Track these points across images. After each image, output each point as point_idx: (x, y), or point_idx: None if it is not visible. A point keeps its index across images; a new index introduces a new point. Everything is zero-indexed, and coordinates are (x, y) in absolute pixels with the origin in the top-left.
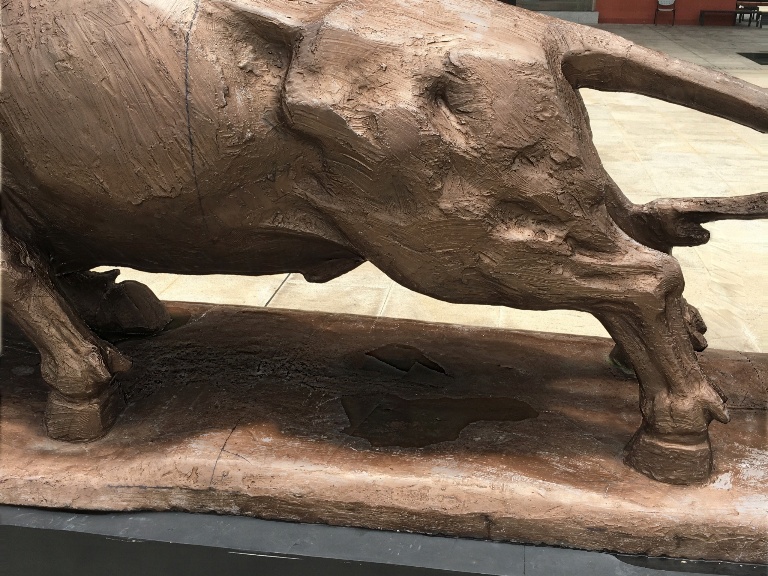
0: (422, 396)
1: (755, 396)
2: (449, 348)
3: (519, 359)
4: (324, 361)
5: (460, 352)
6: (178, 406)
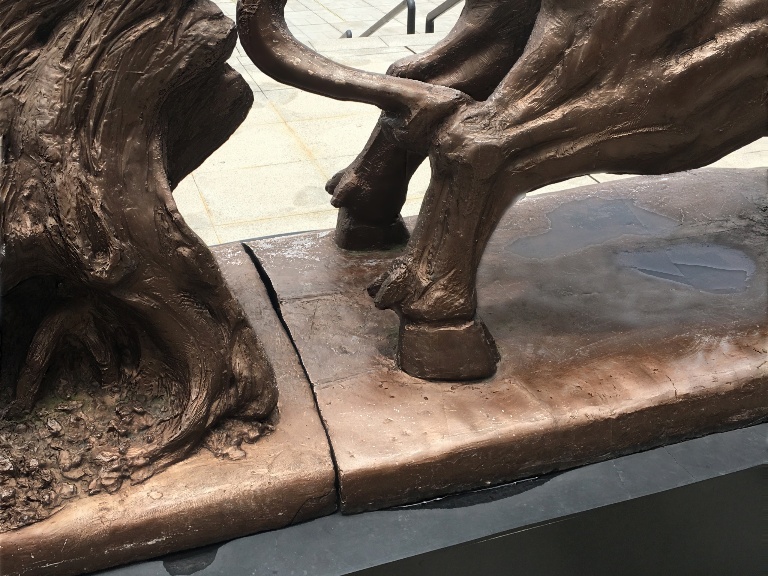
0: (620, 239)
1: (303, 319)
2: (679, 300)
3: (590, 307)
4: (758, 247)
5: (660, 297)
6: (767, 182)
